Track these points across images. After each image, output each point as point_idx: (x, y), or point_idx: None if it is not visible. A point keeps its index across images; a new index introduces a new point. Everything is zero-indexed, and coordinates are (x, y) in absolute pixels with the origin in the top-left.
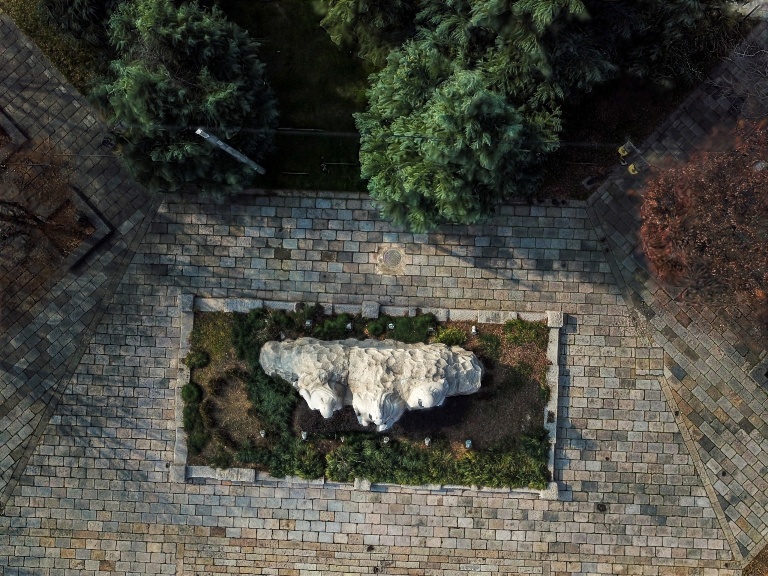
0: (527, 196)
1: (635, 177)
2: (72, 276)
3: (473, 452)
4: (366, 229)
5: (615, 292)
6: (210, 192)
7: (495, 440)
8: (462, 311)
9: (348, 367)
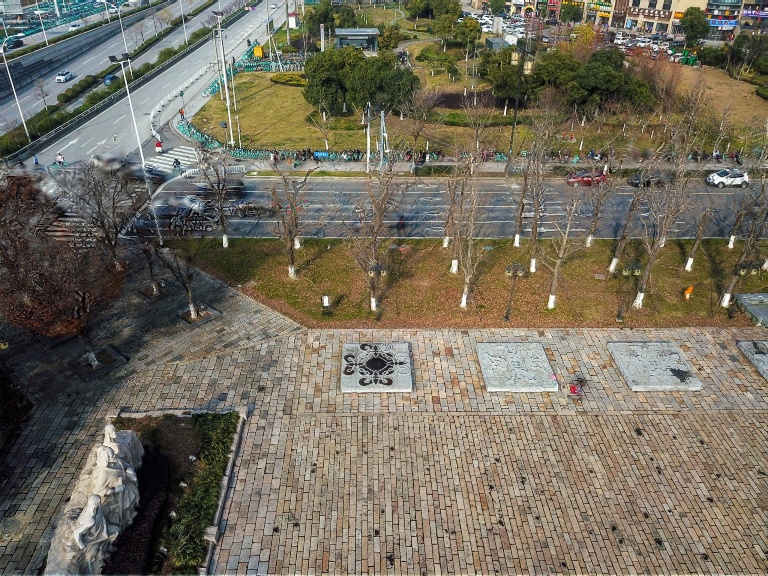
0: (7, 430)
1: (32, 382)
2: None
3: (200, 455)
4: None
5: (110, 388)
6: None
7: (195, 444)
8: None
9: (74, 509)
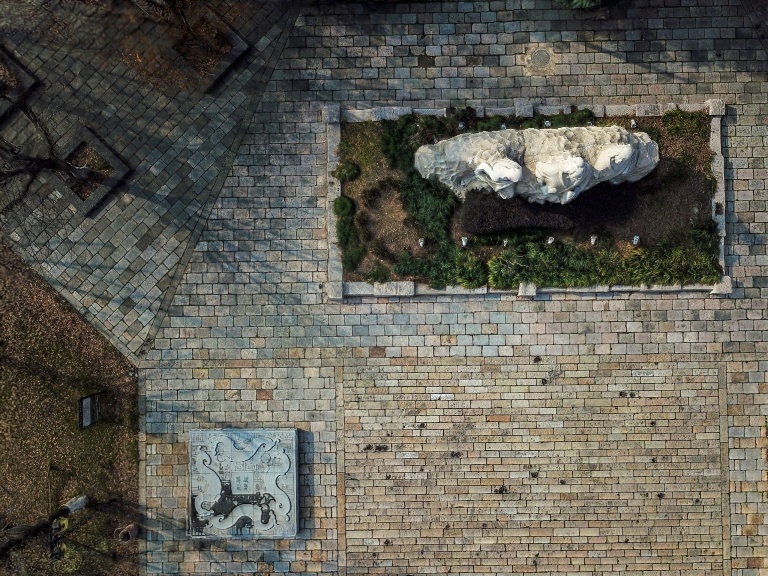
0: None
1: None
2: (210, 98)
3: (641, 248)
4: (511, 30)
5: None
6: None
7: (662, 236)
8: (618, 106)
9: (524, 143)
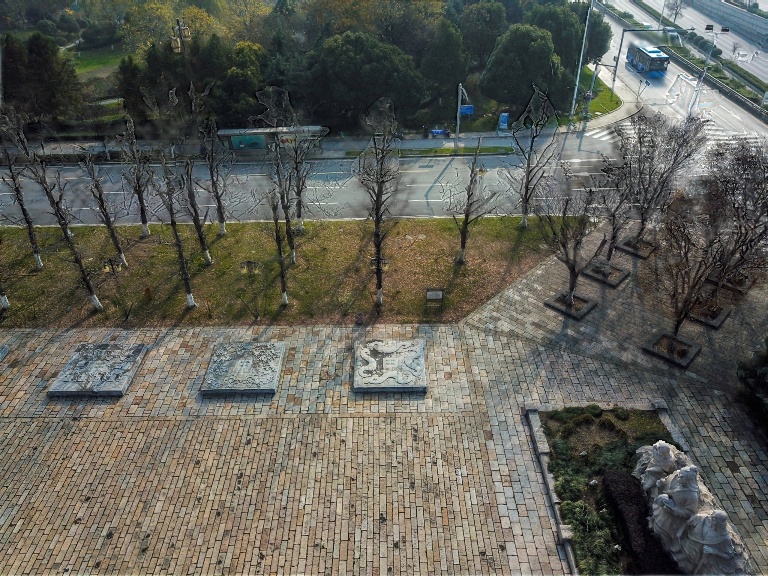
0: None
1: None
2: (641, 351)
3: None
4: None
5: None
6: (765, 397)
7: None
8: None
9: None
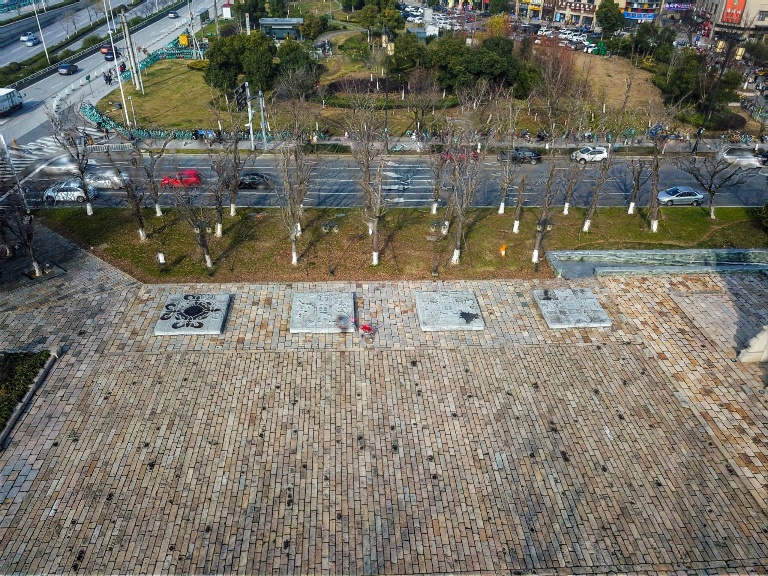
0: None
1: None
2: None
3: (2, 385)
4: None
5: None
6: None
7: (1, 377)
8: None
9: None
